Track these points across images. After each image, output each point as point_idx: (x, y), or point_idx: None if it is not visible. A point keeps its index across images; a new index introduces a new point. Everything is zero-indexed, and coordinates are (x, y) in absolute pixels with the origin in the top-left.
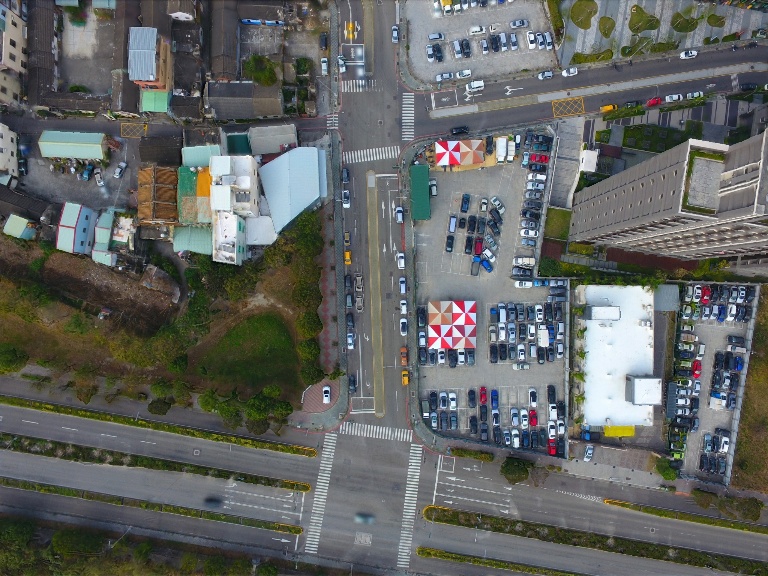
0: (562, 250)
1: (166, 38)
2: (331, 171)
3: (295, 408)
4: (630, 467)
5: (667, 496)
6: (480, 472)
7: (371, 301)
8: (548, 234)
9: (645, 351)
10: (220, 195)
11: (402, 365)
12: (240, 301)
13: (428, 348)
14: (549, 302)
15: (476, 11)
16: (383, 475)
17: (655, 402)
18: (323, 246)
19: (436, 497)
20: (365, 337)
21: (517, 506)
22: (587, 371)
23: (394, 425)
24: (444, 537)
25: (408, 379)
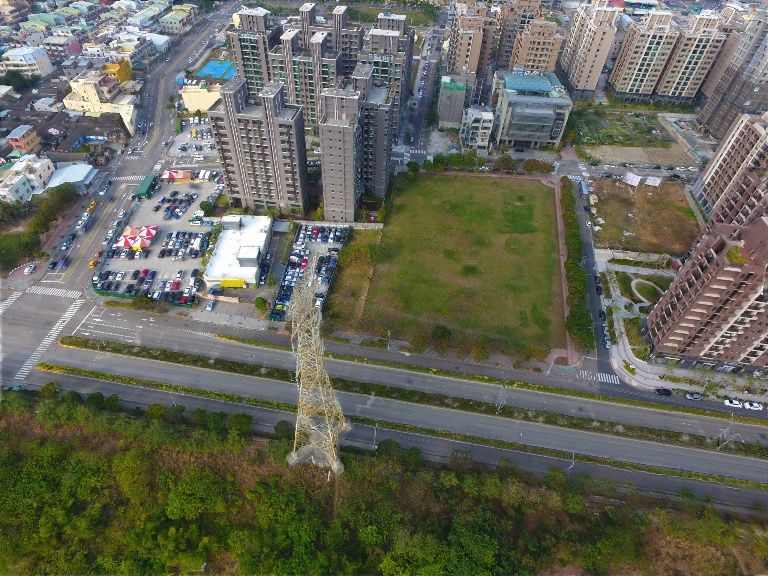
0: (225, 210)
1: (40, 136)
2: (101, 182)
3: (2, 278)
4: (243, 316)
5: (270, 335)
6: (122, 317)
7: (92, 230)
8: (218, 203)
9: (261, 245)
10: (19, 165)
11: (95, 258)
12: (6, 229)
13: (118, 250)
14: (210, 231)
15: (211, 139)
16: (42, 316)
17: (252, 257)
18: (72, 199)
19: (77, 331)
20: (78, 245)
21: (141, 338)
22: (217, 252)
23: (70, 288)
24: (68, 357)
25: (94, 263)
